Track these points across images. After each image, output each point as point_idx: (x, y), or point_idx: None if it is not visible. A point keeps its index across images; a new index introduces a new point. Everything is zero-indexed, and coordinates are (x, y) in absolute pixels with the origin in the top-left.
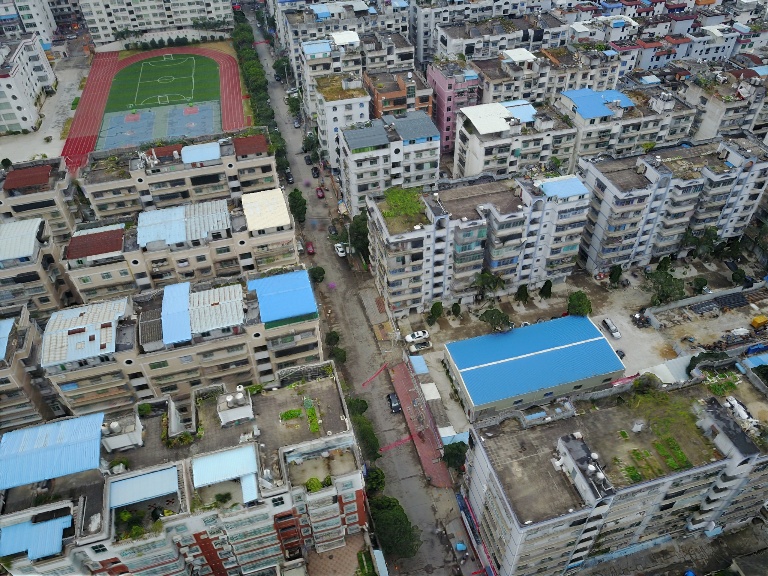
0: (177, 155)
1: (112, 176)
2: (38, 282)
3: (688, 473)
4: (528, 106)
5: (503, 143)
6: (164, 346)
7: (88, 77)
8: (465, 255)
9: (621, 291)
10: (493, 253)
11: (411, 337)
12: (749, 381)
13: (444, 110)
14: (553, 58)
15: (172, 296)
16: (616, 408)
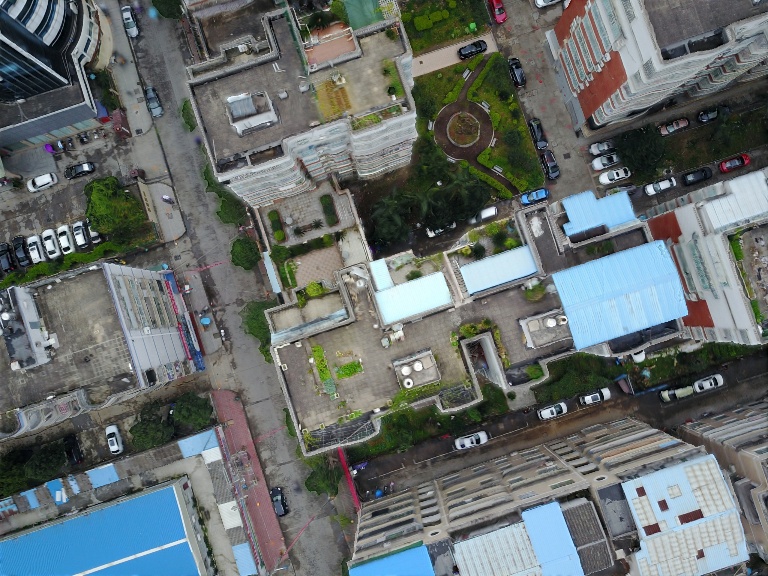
0: None
1: None
2: None
3: None
4: None
5: None
6: None
7: None
8: None
9: None
10: None
11: None
12: None
13: None
14: None
15: None
16: None
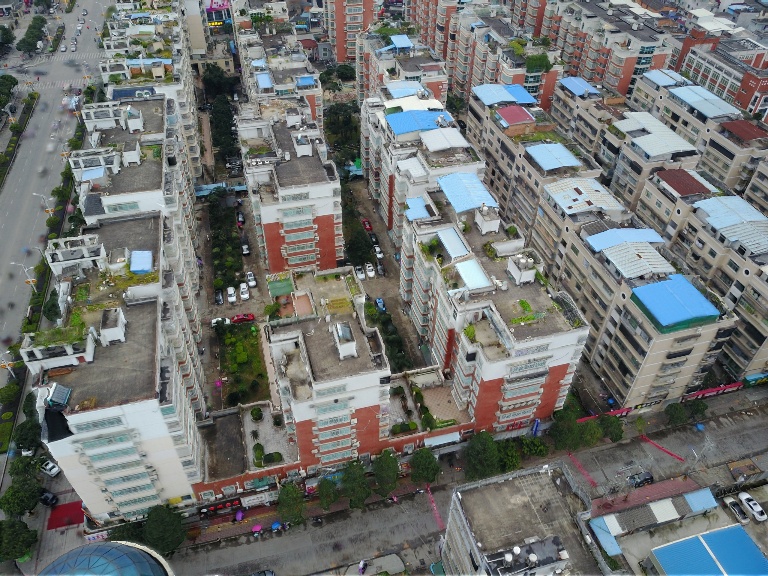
0: None
1: None
2: (638, 176)
3: None
4: None
5: None
6: None
7: None
8: None
9: None
10: None
11: (746, 497)
12: None
13: None
14: None
15: (641, 233)
16: None
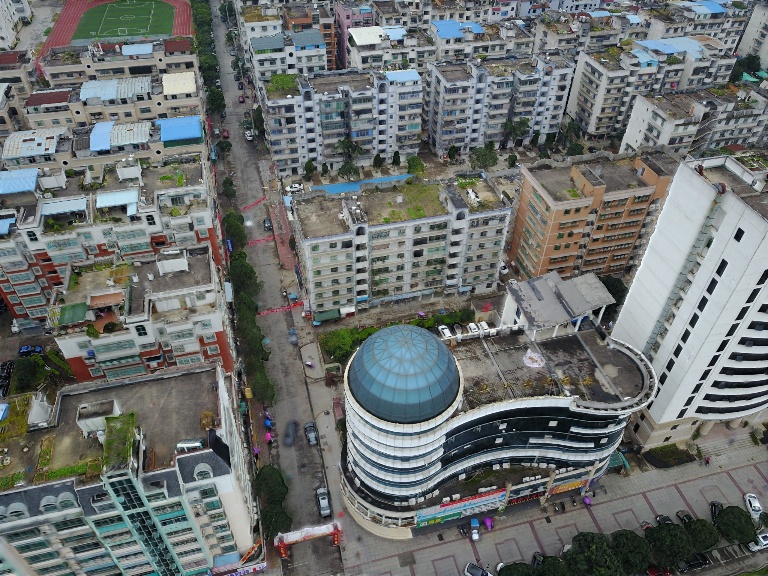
0: (118, 49)
1: (67, 63)
2: (4, 126)
3: (423, 221)
4: (401, 29)
5: (376, 54)
6: (91, 153)
7: (60, 13)
8: (329, 123)
9: (457, 166)
10: (352, 125)
11: (289, 187)
12: (487, 182)
13: (345, 37)
14: (438, 1)
15: (100, 127)
16: (392, 192)
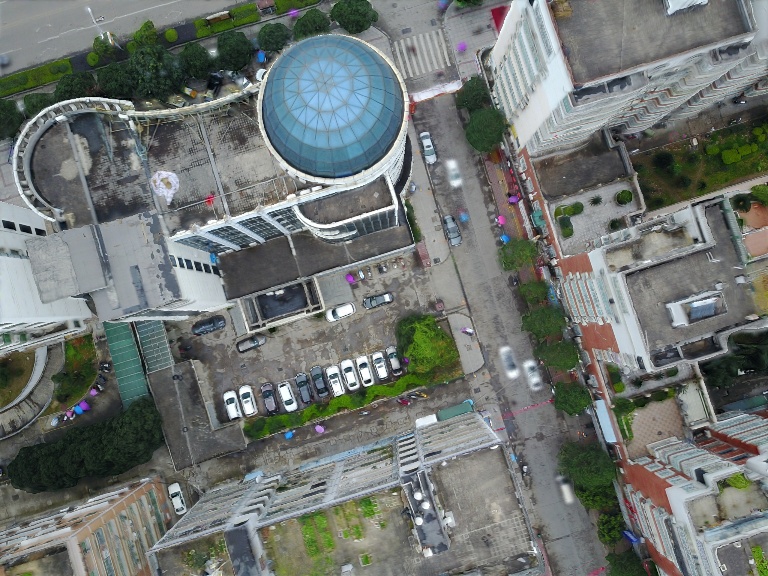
0: None
1: None
2: None
3: None
4: None
5: None
6: None
7: None
8: None
9: None
10: None
11: None
12: None
13: None
14: None
15: None
16: None
